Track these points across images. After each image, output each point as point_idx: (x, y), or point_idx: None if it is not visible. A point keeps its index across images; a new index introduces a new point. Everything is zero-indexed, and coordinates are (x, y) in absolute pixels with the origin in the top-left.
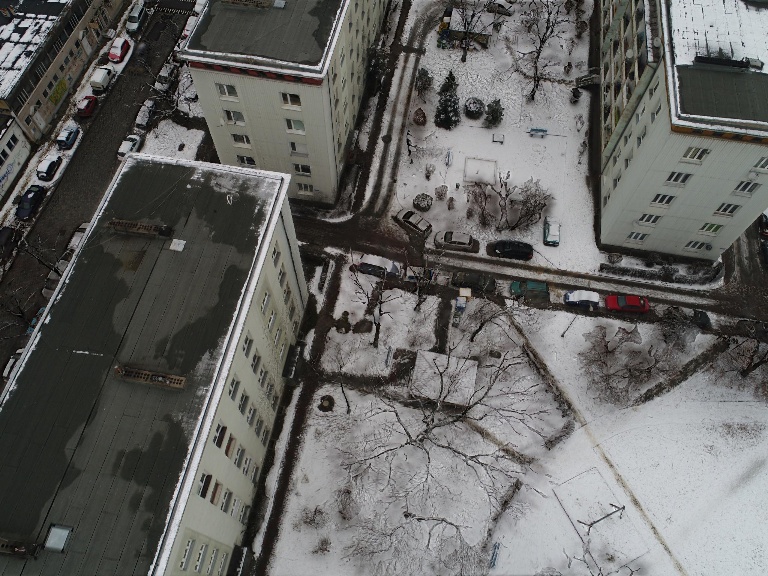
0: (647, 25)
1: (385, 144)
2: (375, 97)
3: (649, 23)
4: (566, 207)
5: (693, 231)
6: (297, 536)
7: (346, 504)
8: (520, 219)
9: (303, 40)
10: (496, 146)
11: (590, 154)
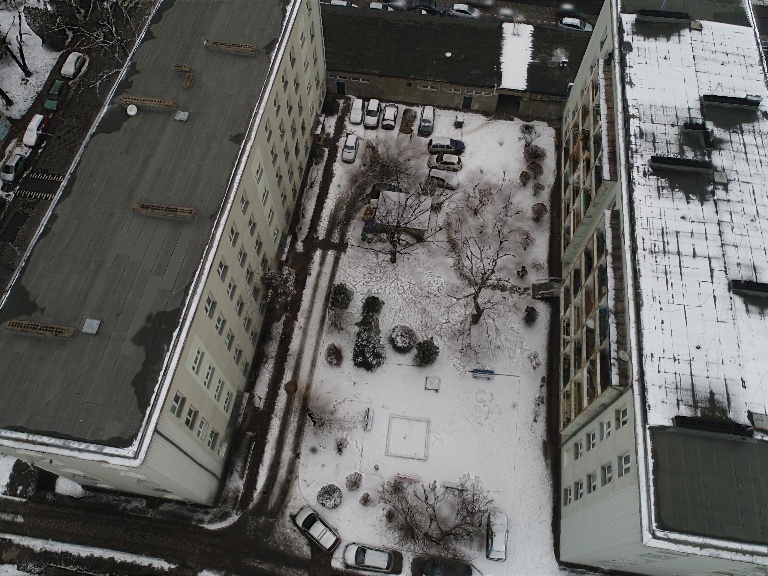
0: (611, 316)
1: (288, 396)
2: (279, 322)
3: (614, 312)
4: (517, 494)
5: (680, 573)
6: None
7: None
8: (454, 528)
9: (117, 395)
10: (429, 395)
11: (548, 405)
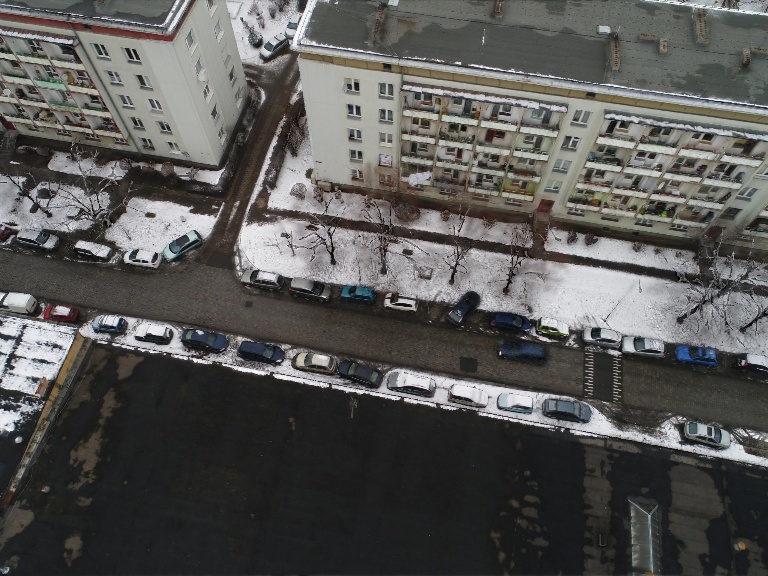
0: None
1: None
2: None
3: None
4: None
5: None
6: None
7: None
8: None
9: None
10: None
11: None
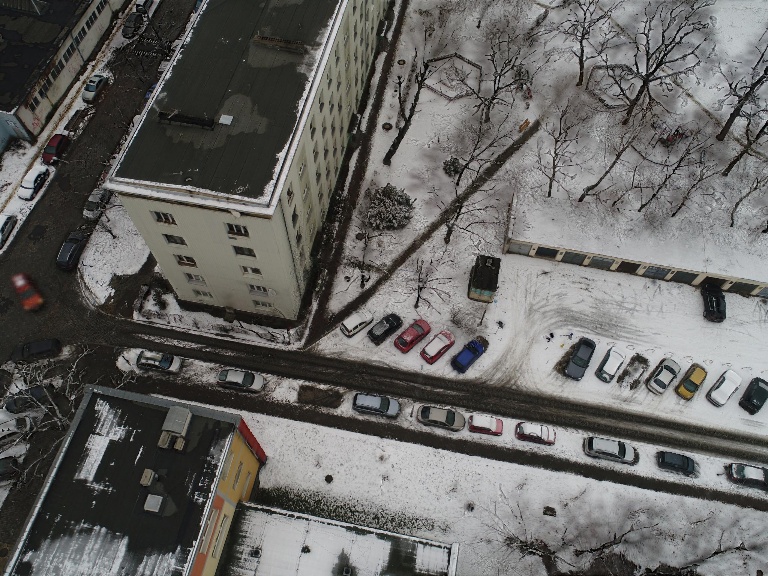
0: None
1: None
2: None
3: None
4: None
5: None
6: (413, 33)
7: (444, 9)
8: None
9: None
10: None
11: None
